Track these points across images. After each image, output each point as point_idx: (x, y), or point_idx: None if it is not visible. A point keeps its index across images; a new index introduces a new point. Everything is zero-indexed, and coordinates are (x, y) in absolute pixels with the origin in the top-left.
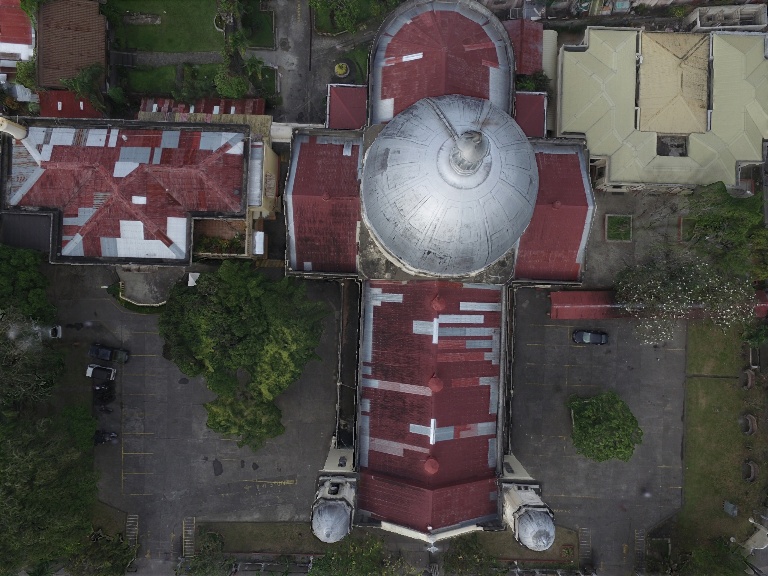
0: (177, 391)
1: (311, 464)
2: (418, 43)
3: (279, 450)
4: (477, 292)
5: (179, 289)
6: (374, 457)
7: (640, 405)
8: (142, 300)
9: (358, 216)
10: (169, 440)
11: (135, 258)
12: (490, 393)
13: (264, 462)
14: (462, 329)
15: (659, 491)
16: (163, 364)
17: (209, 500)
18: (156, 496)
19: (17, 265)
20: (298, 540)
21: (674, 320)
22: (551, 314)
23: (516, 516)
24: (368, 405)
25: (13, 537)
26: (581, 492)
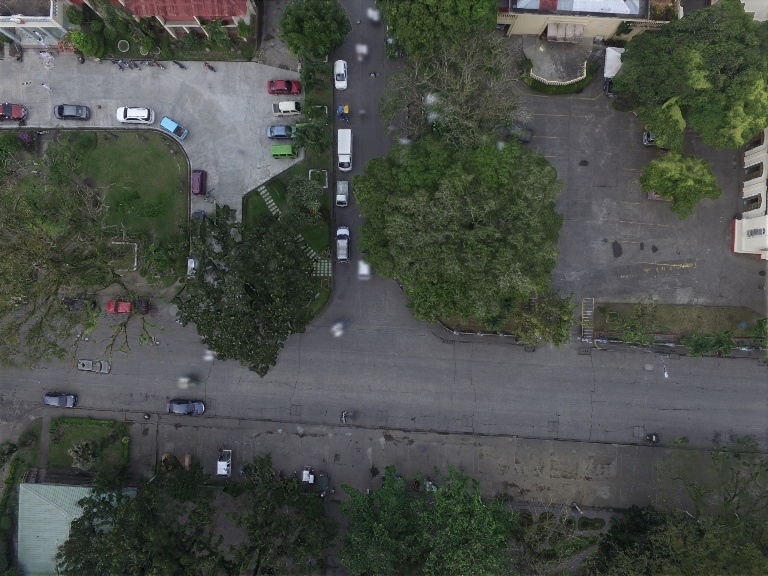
0: (577, 173)
1: (710, 248)
2: None
3: (678, 233)
4: None
5: (651, 34)
6: None
7: None
8: (548, 79)
9: None
10: (569, 221)
11: (589, 12)
12: None
13: (663, 245)
14: None
15: None
16: (563, 146)
17: (609, 281)
18: (556, 276)
19: (491, 7)
20: (697, 323)
21: None
22: None
23: None
24: None
25: (535, 247)
26: None
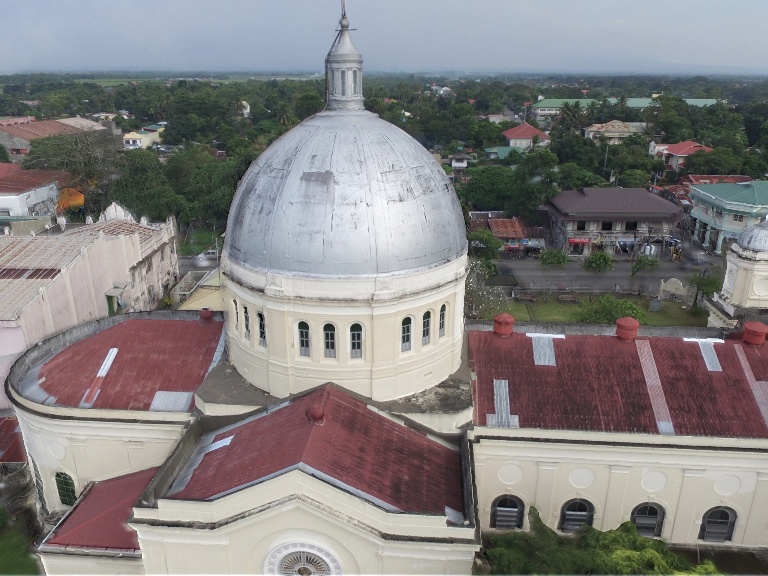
0: None
1: None
2: (91, 356)
3: None
4: None
5: None
6: None
7: None
8: None
9: (358, 402)
10: None
11: None
12: None
13: None
14: None
15: None
16: None
17: None
18: None
19: None
20: None
21: None
22: None
23: (760, 256)
24: None
25: None
26: None
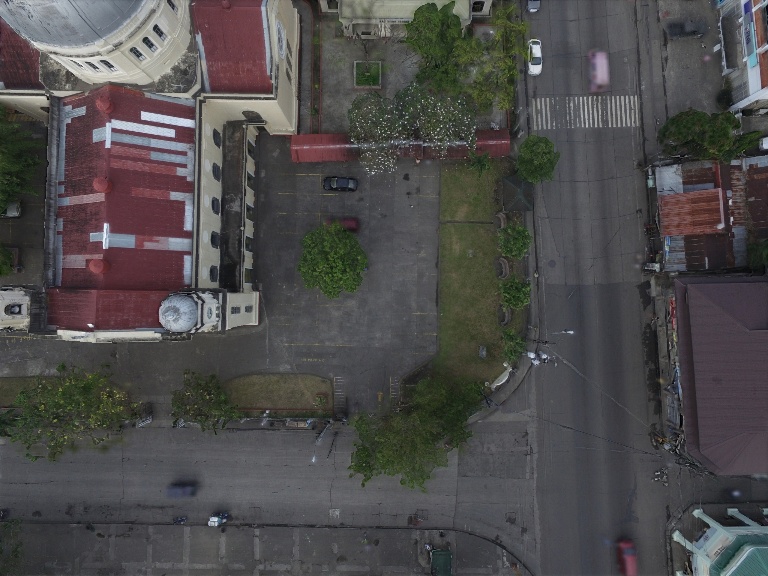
0: None
1: None
2: None
3: None
4: (165, 105)
5: None
6: (66, 274)
7: (394, 252)
8: None
9: None
10: None
11: None
12: (185, 209)
13: None
14: (145, 139)
15: (414, 338)
16: None
17: None
18: None
19: None
20: None
21: (393, 146)
22: (292, 156)
23: None
24: (61, 224)
25: None
26: (335, 341)
